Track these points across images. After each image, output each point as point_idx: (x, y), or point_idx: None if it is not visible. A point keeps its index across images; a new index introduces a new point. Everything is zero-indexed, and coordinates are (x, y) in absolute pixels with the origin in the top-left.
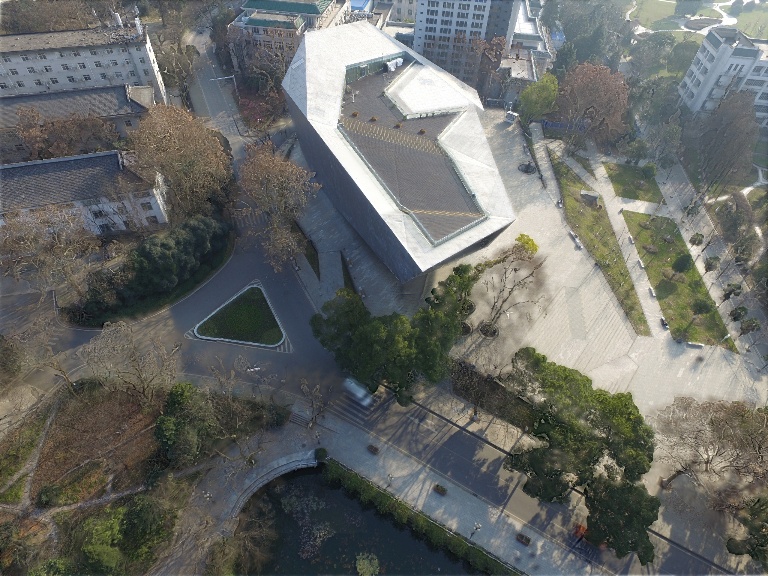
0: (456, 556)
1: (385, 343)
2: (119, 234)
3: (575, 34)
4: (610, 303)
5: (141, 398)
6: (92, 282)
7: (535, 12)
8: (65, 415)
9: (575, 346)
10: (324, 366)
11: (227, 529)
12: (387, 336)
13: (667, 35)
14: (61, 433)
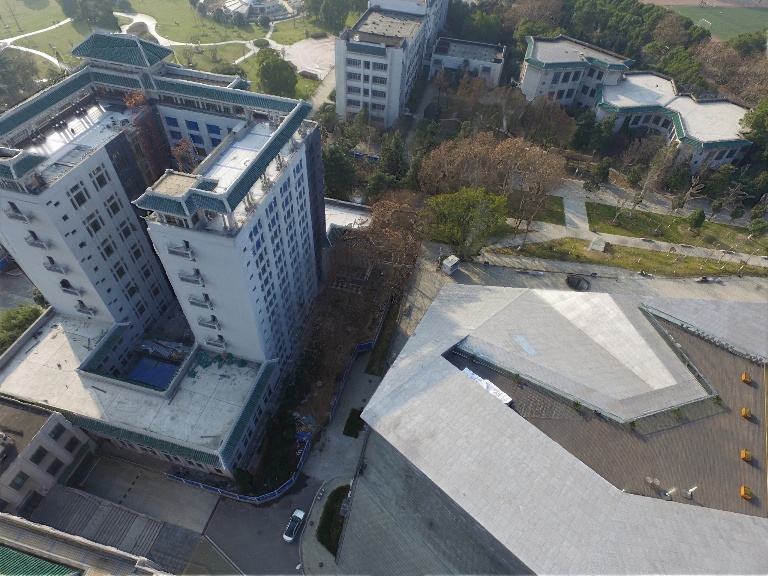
0: None
1: None
2: None
3: None
4: None
5: None
6: None
7: None
8: None
9: None
10: None
11: None
12: None
13: (233, 67)
14: None
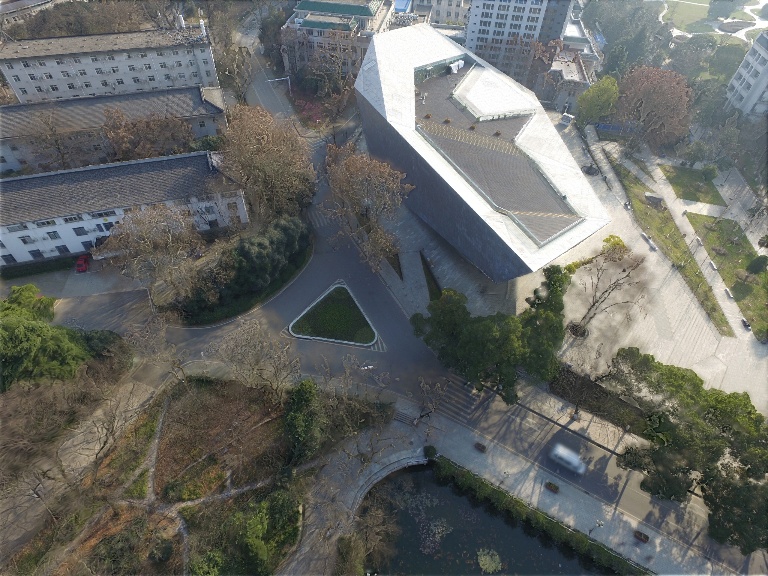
0: (572, 553)
1: (497, 342)
2: (203, 234)
3: (616, 37)
4: (692, 304)
5: (272, 395)
6: (198, 281)
7: (575, 14)
8: (176, 412)
9: (664, 346)
10: (420, 365)
11: (371, 524)
12: (500, 335)
13: (709, 38)
14: (175, 429)
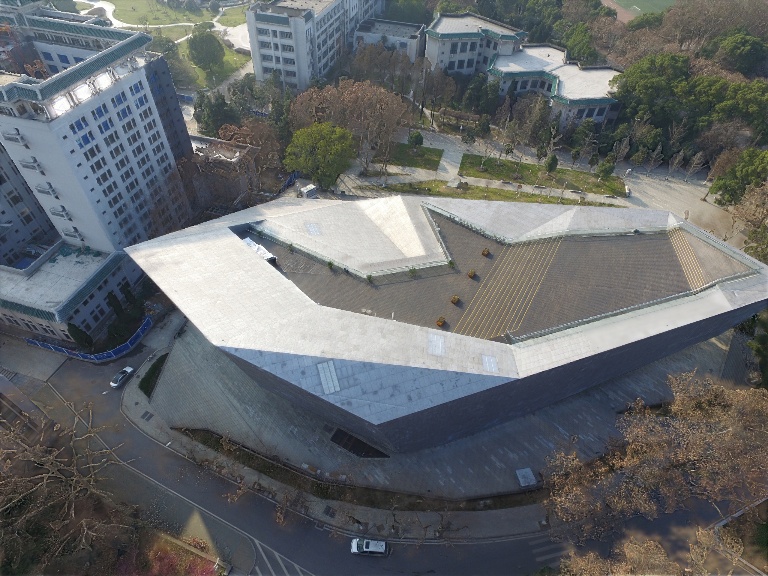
0: None
1: None
2: None
3: None
4: None
5: None
6: None
7: None
8: None
9: None
10: None
11: None
12: None
13: (164, 39)
14: None
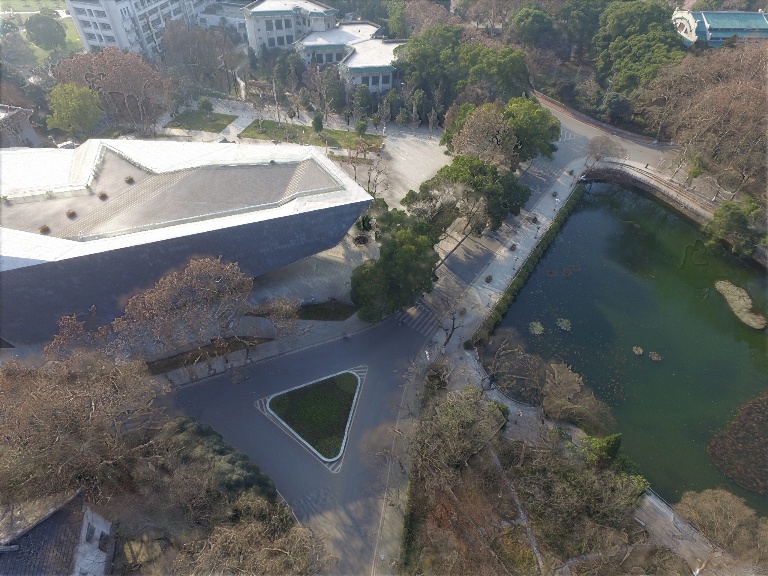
0: None
1: None
2: None
3: None
4: None
5: None
6: None
7: None
8: None
9: None
10: (385, 340)
11: None
12: None
13: (1, 21)
14: None
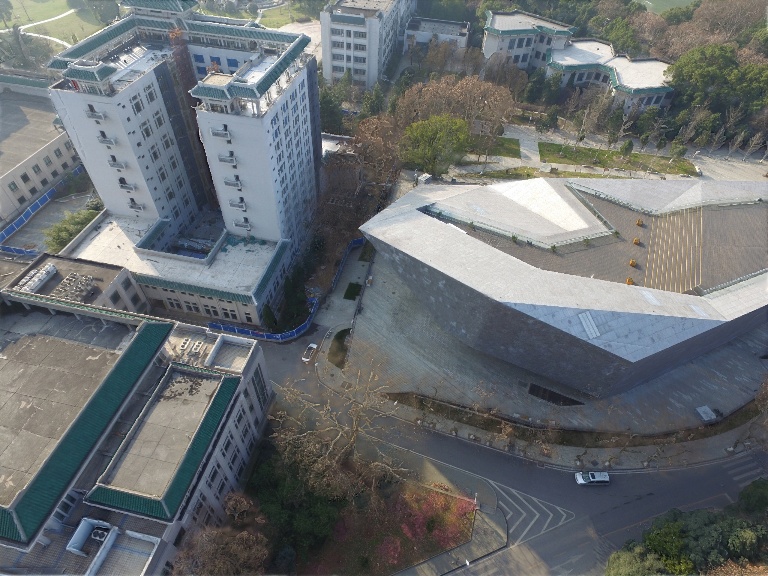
0: None
1: None
2: None
3: None
4: None
5: None
6: None
7: None
8: None
9: None
10: None
11: None
12: None
13: None
14: None
